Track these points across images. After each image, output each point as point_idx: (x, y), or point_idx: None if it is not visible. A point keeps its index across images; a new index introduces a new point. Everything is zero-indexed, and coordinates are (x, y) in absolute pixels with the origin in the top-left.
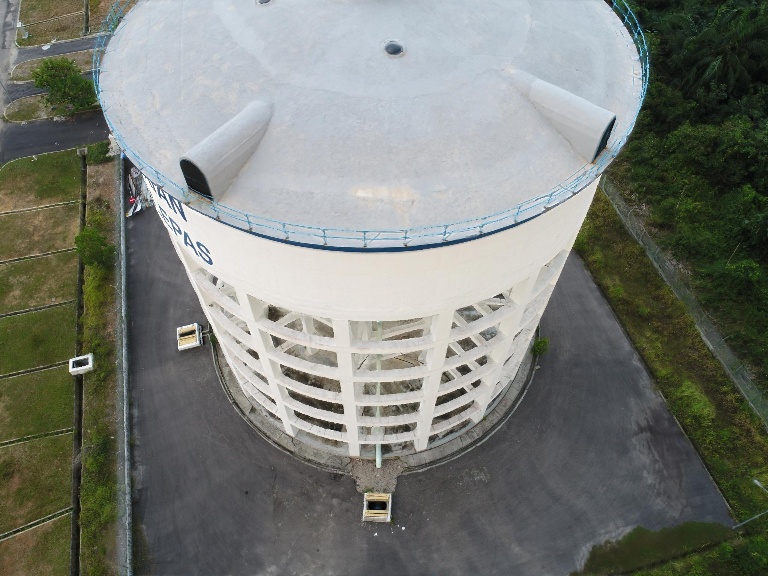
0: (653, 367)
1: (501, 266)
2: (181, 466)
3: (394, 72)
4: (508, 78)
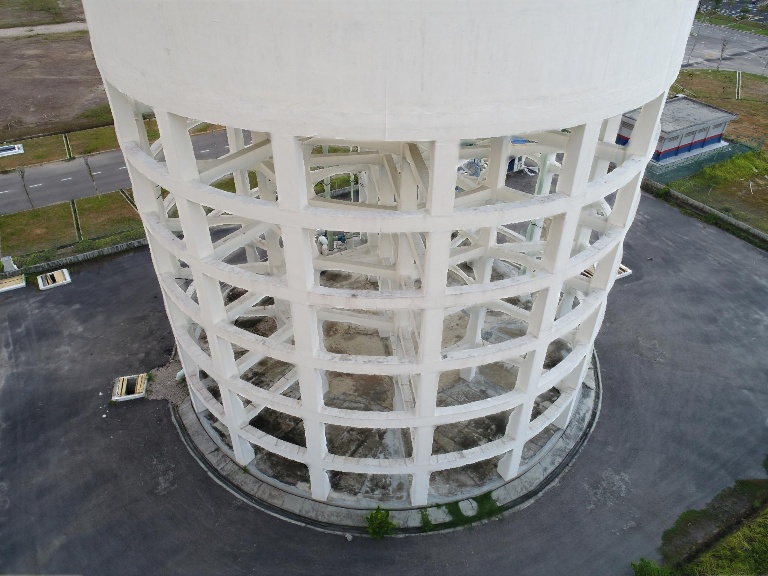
0: None
1: None
2: None
3: None
4: None
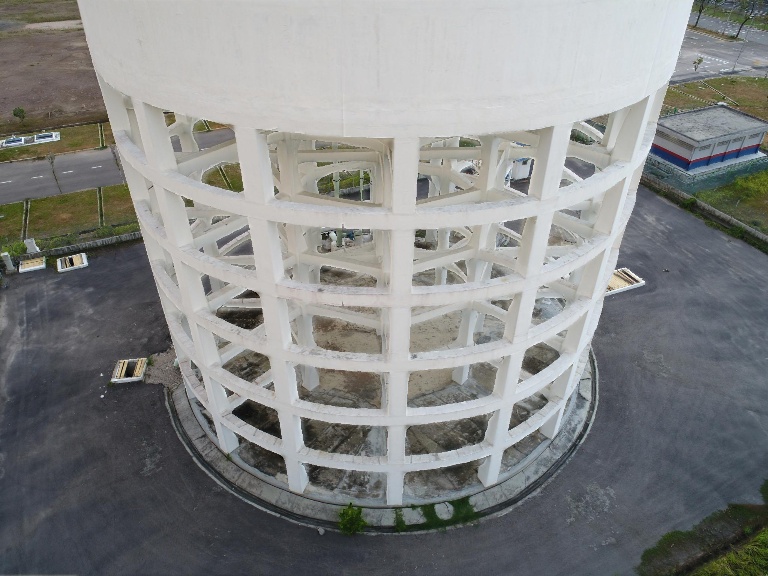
0: None
1: None
2: None
3: None
4: None
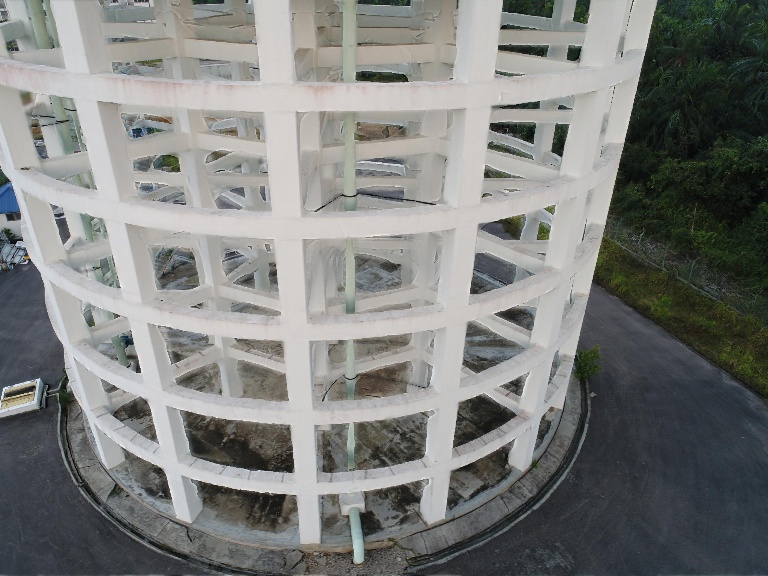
0: (757, 384)
1: None
2: None
3: None
4: None
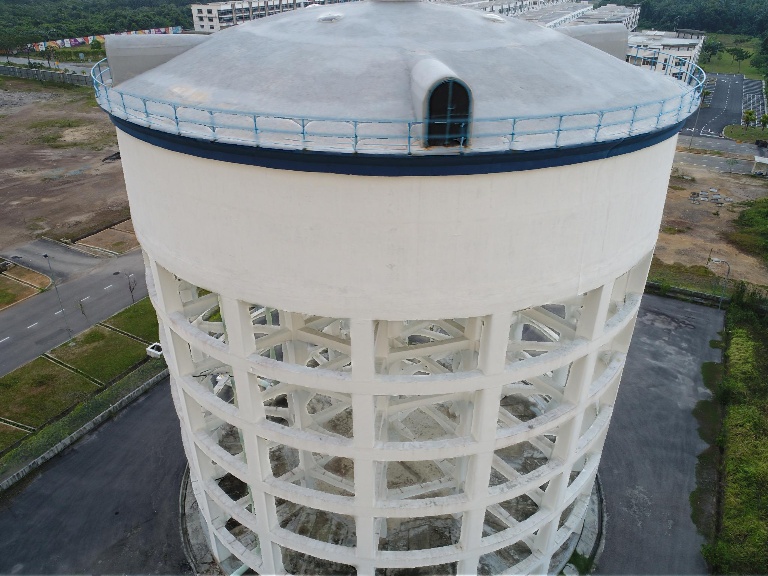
0: None
1: (283, 250)
2: (113, 455)
3: (308, 29)
4: (408, 56)
